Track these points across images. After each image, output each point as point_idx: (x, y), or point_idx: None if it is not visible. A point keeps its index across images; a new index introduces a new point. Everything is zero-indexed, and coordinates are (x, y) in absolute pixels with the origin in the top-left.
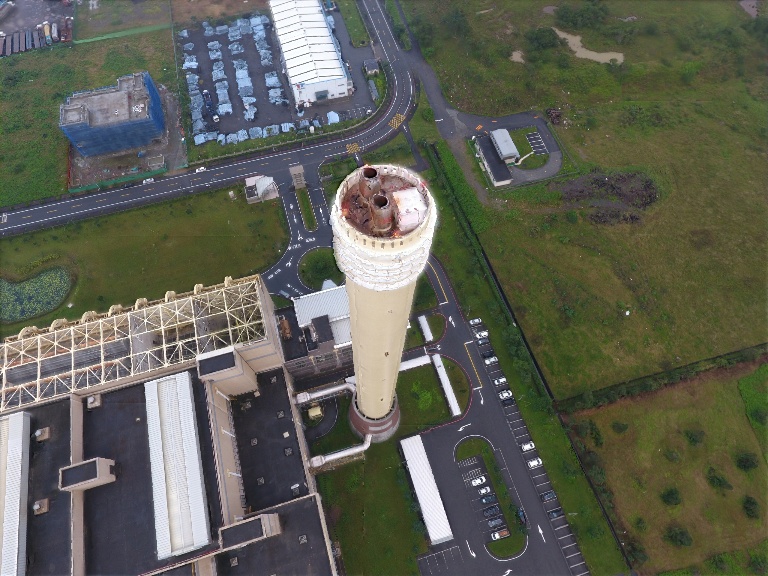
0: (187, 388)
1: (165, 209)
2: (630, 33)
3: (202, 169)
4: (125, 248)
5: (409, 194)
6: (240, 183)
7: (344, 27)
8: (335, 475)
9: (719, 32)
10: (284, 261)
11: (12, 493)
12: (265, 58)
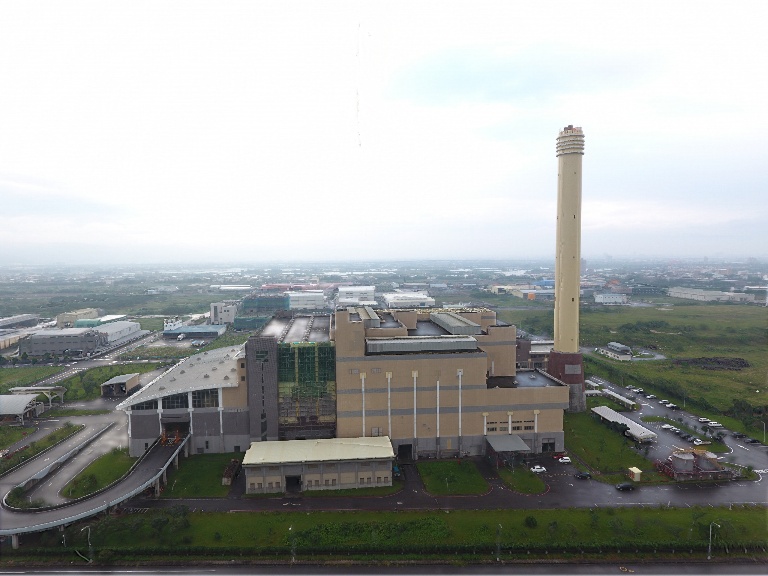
0: None
1: None
2: (688, 326)
3: None
4: None
5: None
6: None
7: None
8: None
9: (753, 328)
10: None
11: (371, 311)
12: None
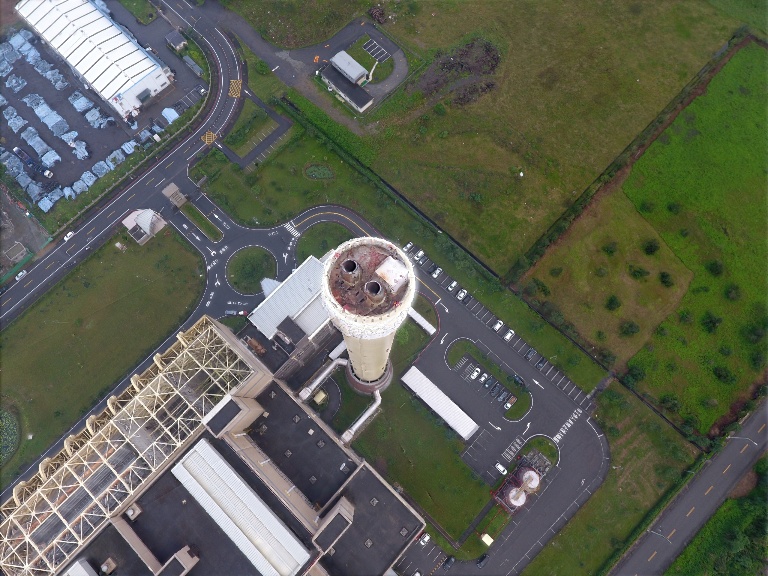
0: (212, 452)
1: (60, 294)
2: None
3: (70, 235)
4: (46, 354)
5: (389, 266)
6: (119, 229)
7: (120, 6)
8: (365, 435)
9: None
10: (211, 283)
11: None
12: (56, 80)
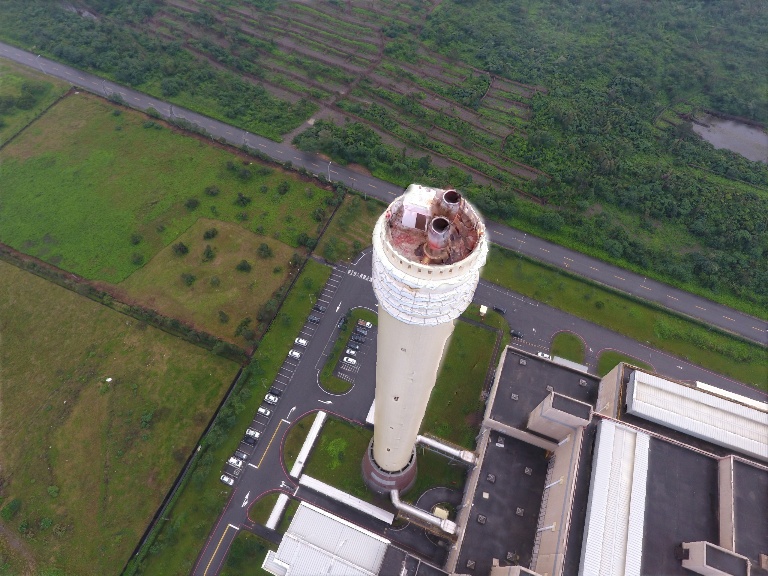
0: None
1: None
2: None
3: None
4: None
5: (416, 198)
6: None
7: None
8: None
9: None
10: None
11: None
12: None
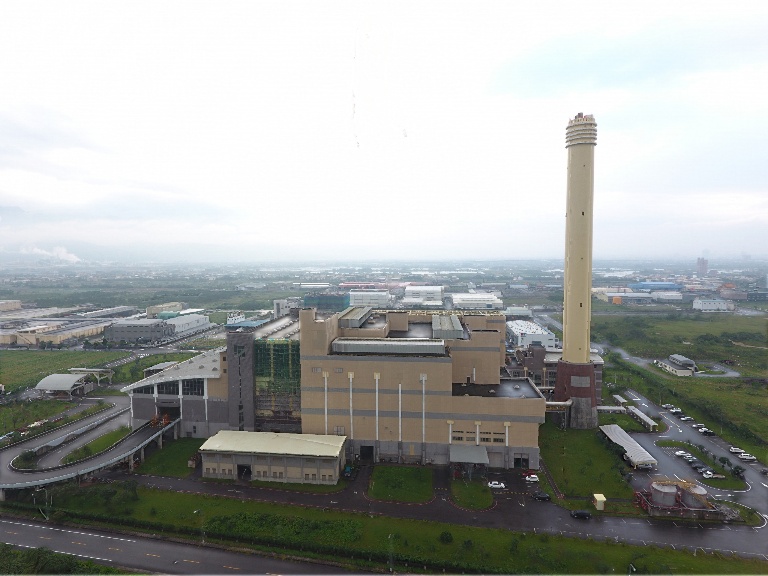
0: (456, 316)
1: None
2: None
3: None
4: None
5: None
6: None
7: None
8: None
9: None
10: None
11: None
12: None
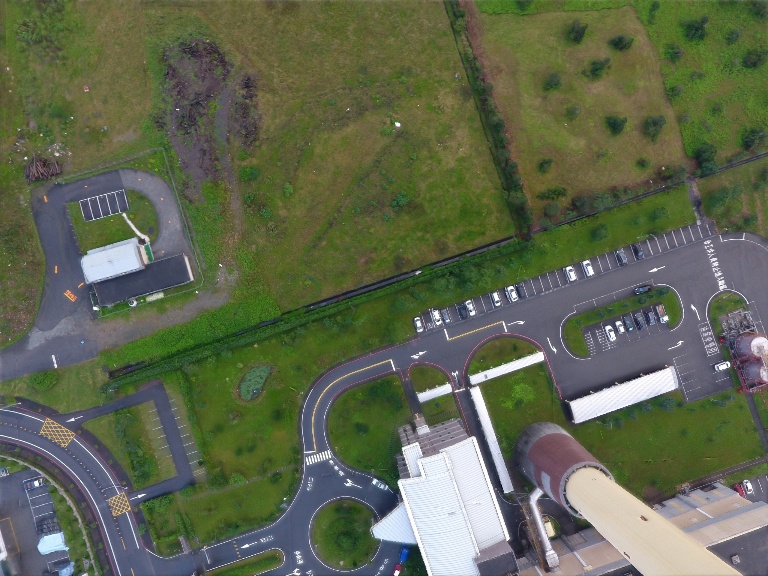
0: None
1: None
2: None
3: None
4: None
5: None
6: None
7: None
8: None
9: None
10: None
11: None
12: None
